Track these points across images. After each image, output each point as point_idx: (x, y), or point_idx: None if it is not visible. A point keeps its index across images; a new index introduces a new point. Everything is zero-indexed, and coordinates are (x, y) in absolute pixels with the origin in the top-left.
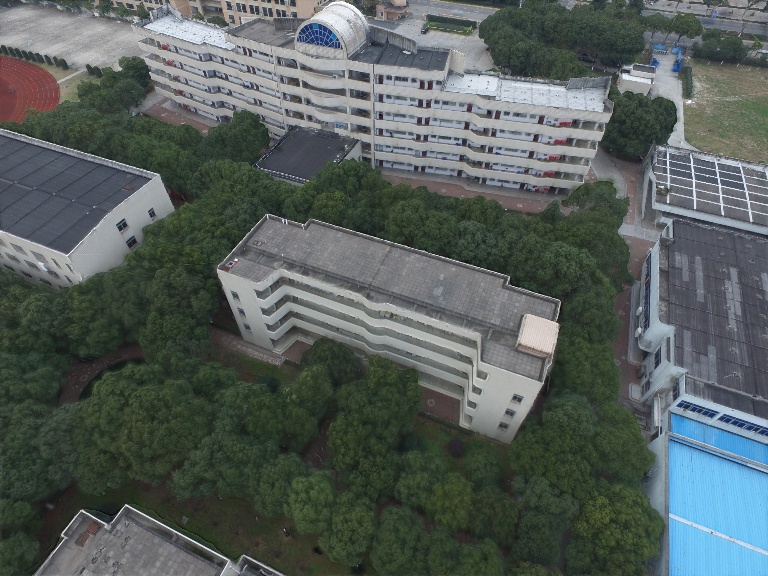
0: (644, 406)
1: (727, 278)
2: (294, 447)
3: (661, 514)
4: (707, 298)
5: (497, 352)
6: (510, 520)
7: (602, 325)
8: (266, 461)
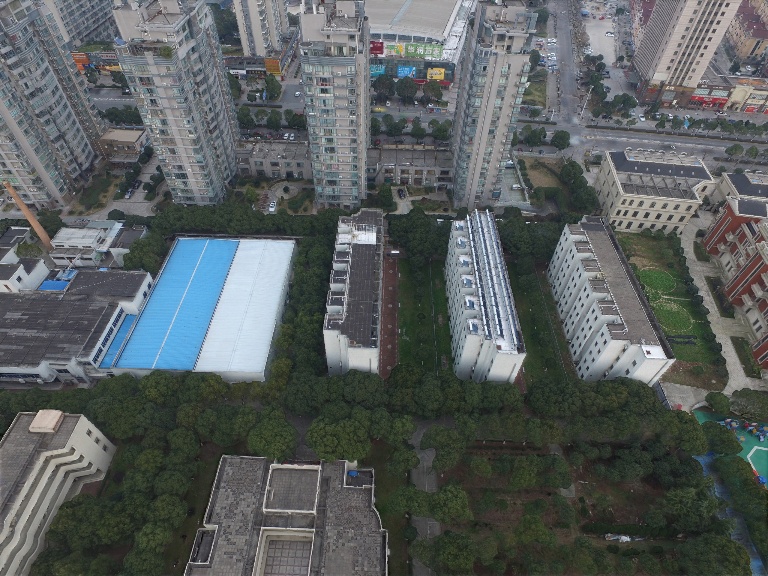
0: (93, 382)
1: (5, 334)
2: (119, 567)
3: (152, 371)
4: (21, 345)
5: (57, 442)
6: (158, 429)
7: (37, 395)
8: (129, 573)
